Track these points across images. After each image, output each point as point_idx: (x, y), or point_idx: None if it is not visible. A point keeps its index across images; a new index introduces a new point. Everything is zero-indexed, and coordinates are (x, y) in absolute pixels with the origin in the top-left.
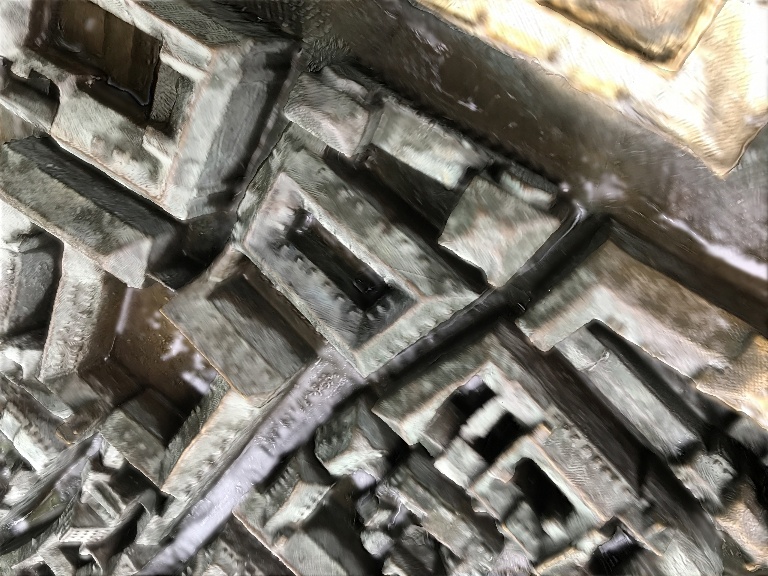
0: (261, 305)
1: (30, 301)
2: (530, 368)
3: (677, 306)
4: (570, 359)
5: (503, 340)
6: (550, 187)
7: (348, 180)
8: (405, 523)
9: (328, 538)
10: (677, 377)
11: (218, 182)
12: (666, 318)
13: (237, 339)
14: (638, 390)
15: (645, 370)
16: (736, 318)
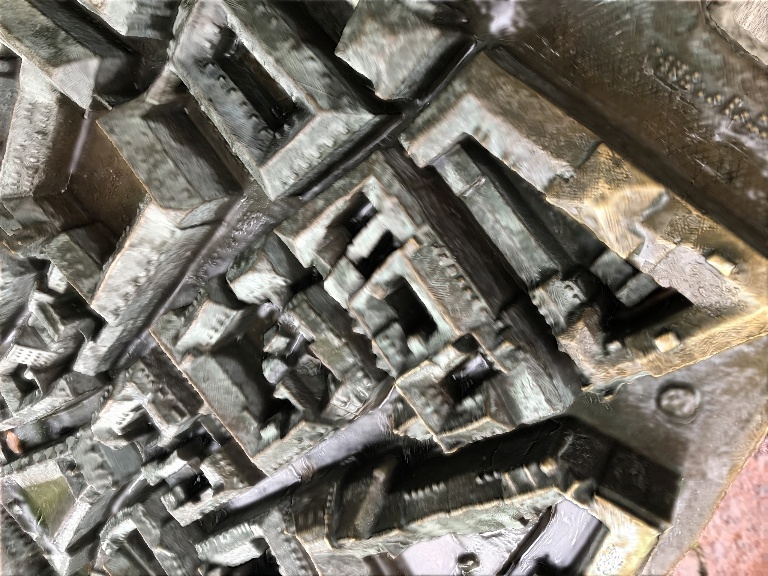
0: (197, 138)
1: None
2: (412, 190)
3: (534, 115)
4: (450, 184)
5: (389, 158)
6: (440, 3)
7: None
8: (301, 353)
9: (235, 367)
10: (553, 217)
11: (161, 4)
12: (523, 127)
13: (164, 158)
14: (508, 217)
15: (521, 204)
16: (585, 128)
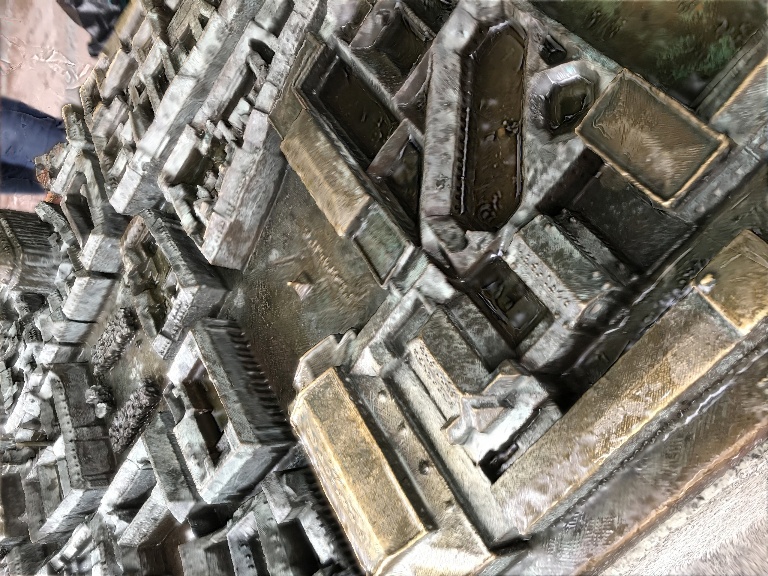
0: None
1: (137, 492)
2: None
3: None
4: None
5: None
6: None
7: (281, 530)
8: None
9: None
10: None
11: (235, 491)
12: None
13: None
14: None
15: None
16: None
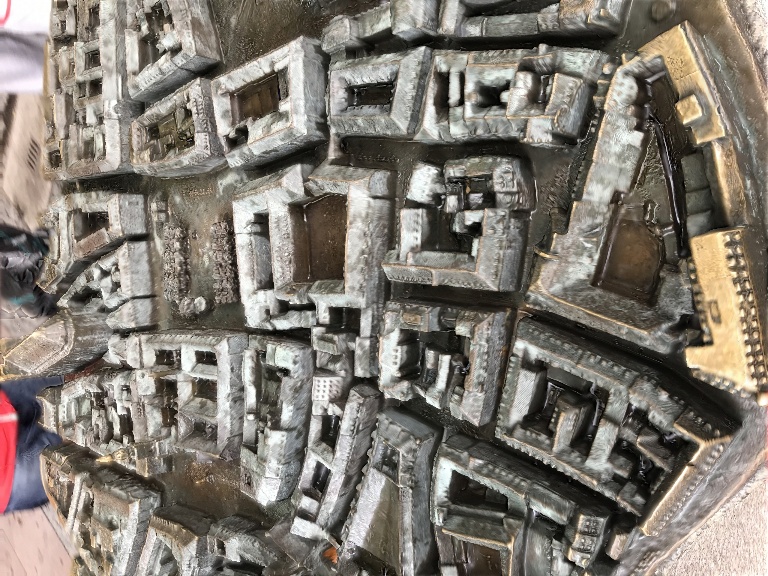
0: None
1: (265, 271)
2: None
3: None
4: (474, 35)
5: None
6: None
7: None
8: None
9: None
10: None
11: (318, 116)
12: None
13: (347, 169)
14: (507, 19)
15: None
16: None
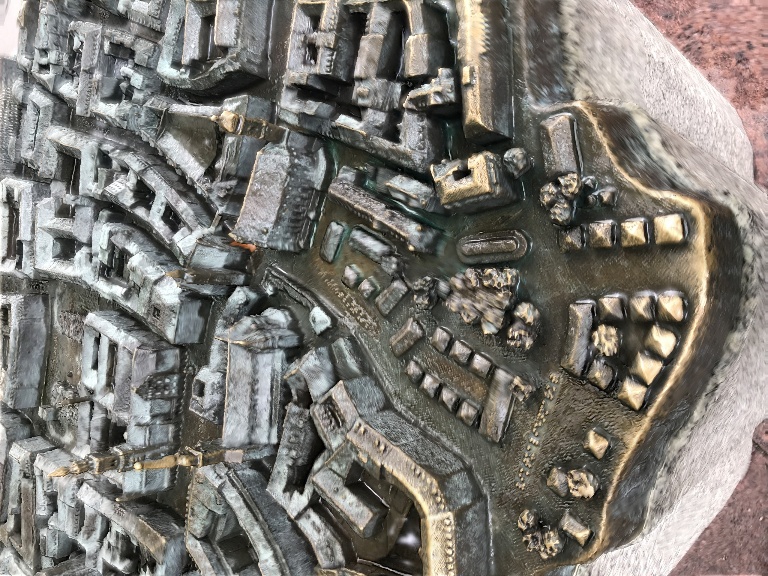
0: None
1: None
2: None
3: None
4: None
5: None
6: None
7: None
8: None
9: None
10: None
11: None
12: None
13: None
14: None
15: None
16: None
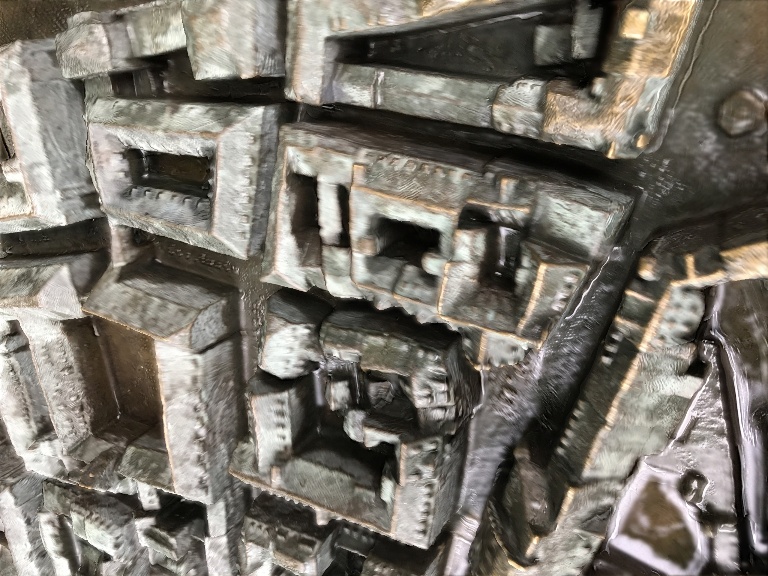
0: (176, 274)
1: None
2: (334, 136)
3: None
4: (360, 103)
5: (295, 125)
6: None
7: None
8: (366, 386)
9: (327, 456)
10: (474, 60)
11: (82, 183)
12: None
13: (149, 299)
14: (425, 83)
15: (435, 70)
16: None
